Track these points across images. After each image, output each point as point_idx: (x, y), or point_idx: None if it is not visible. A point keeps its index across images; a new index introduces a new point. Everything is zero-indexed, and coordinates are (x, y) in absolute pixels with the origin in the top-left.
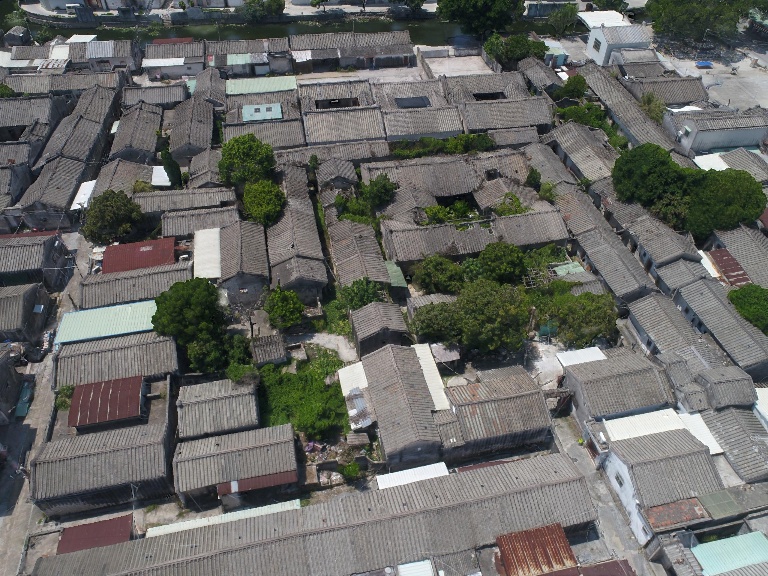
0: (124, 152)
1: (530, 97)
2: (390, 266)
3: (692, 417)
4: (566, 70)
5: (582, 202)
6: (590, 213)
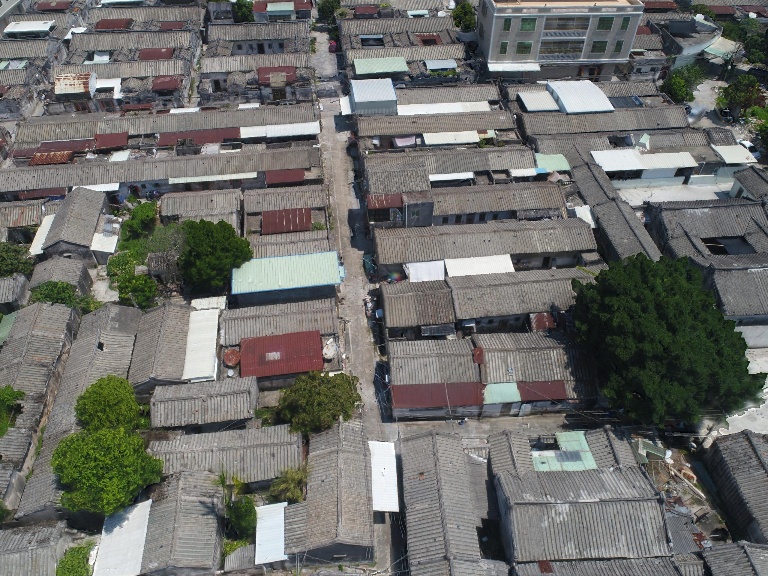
0: None
1: None
2: (5, 334)
3: None
4: None
5: None
6: None
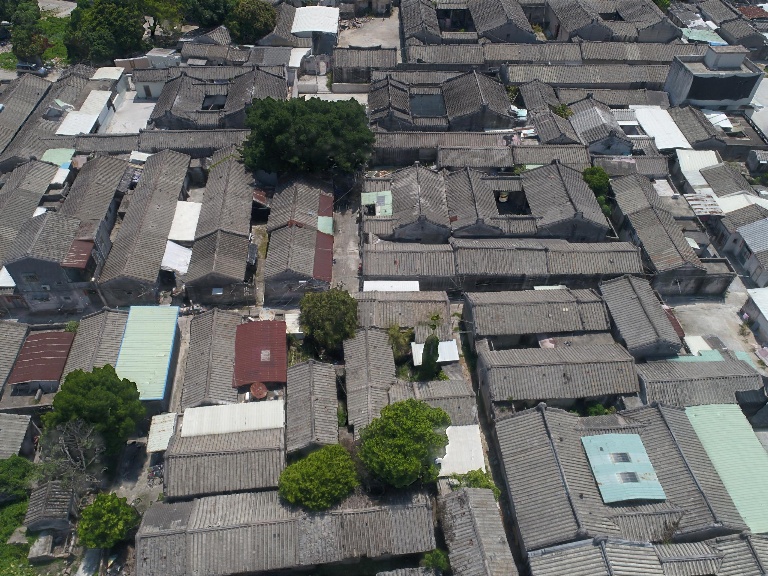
0: None
1: None
2: None
3: None
4: None
5: None
6: None
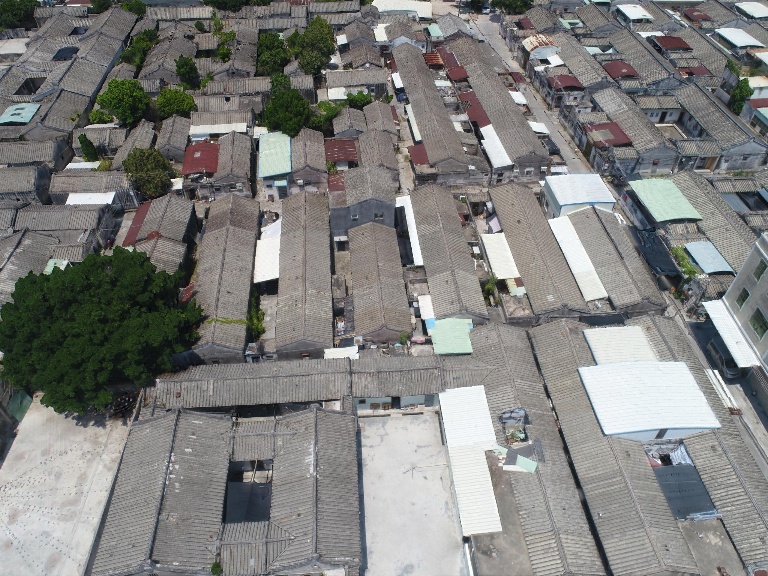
0: (37, 177)
1: (100, 16)
2: None
3: (379, 26)
4: (63, 5)
5: None
6: None
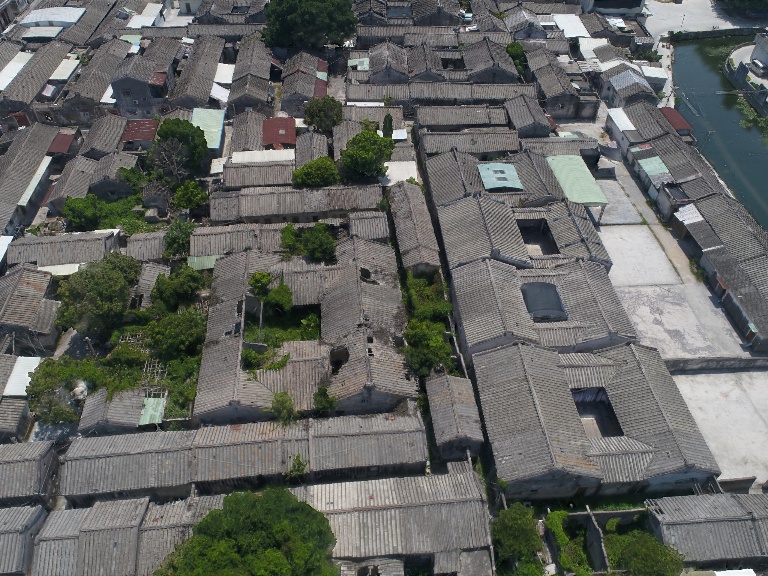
0: None
1: (585, 460)
2: None
3: None
4: None
5: (256, 450)
6: (228, 452)
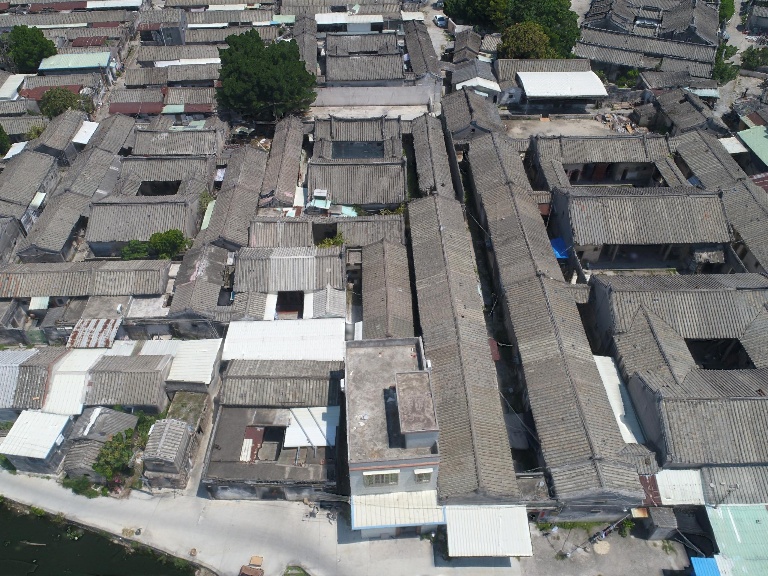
0: None
1: None
2: None
3: None
4: None
5: None
6: None
